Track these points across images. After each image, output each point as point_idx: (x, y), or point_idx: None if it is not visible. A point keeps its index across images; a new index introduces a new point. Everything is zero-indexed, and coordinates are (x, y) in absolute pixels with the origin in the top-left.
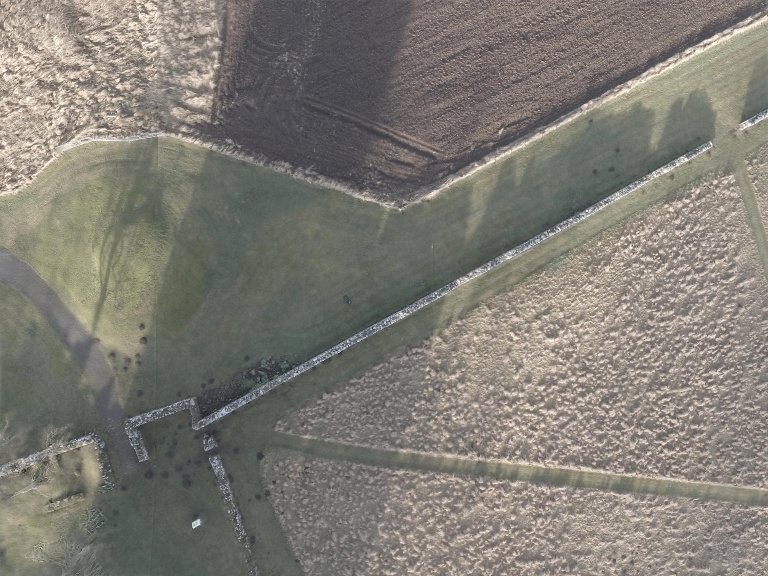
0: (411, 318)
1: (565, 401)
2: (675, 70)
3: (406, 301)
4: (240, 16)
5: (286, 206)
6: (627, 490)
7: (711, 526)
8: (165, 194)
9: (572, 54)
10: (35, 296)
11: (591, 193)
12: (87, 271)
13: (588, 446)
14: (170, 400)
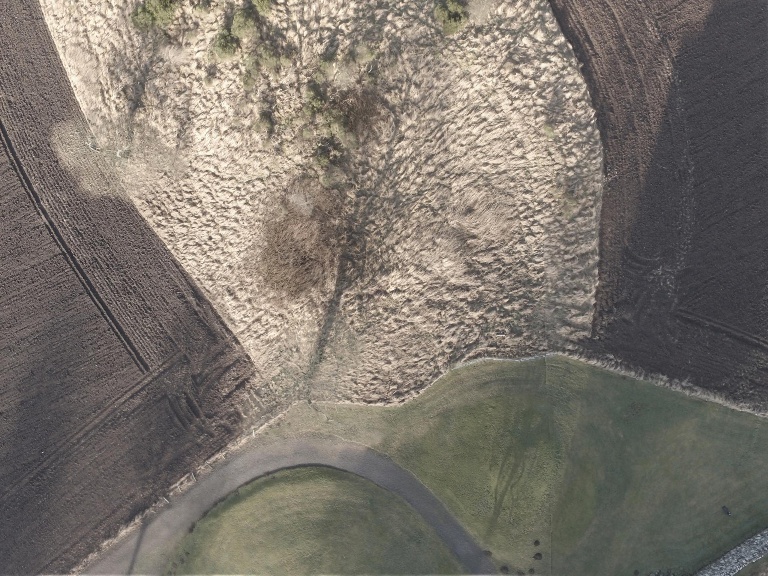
0: None
1: None
2: None
3: None
4: (616, 232)
5: (665, 419)
6: None
7: None
8: (556, 412)
9: None
10: (420, 504)
11: None
12: (480, 486)
13: None
14: None
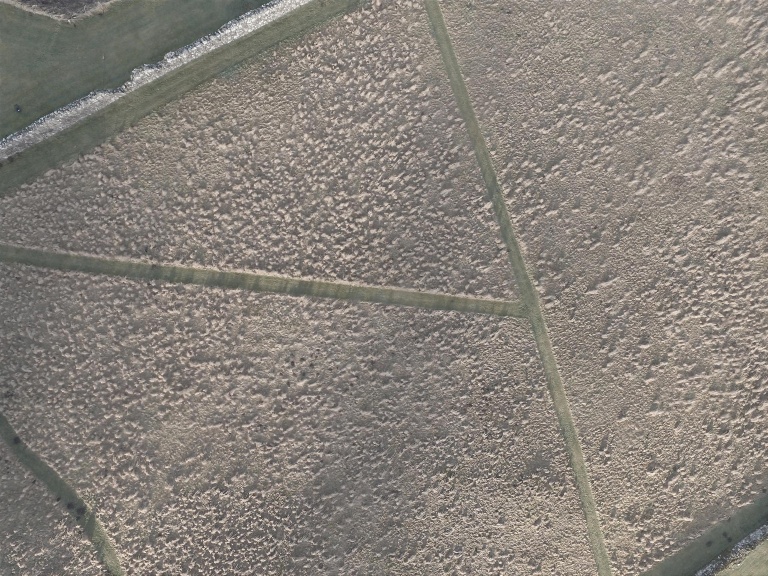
0: (83, 126)
1: (240, 206)
2: None
3: None
4: None
5: None
6: (304, 294)
7: (394, 331)
8: None
9: None
10: None
11: None
12: None
13: (264, 250)
14: None
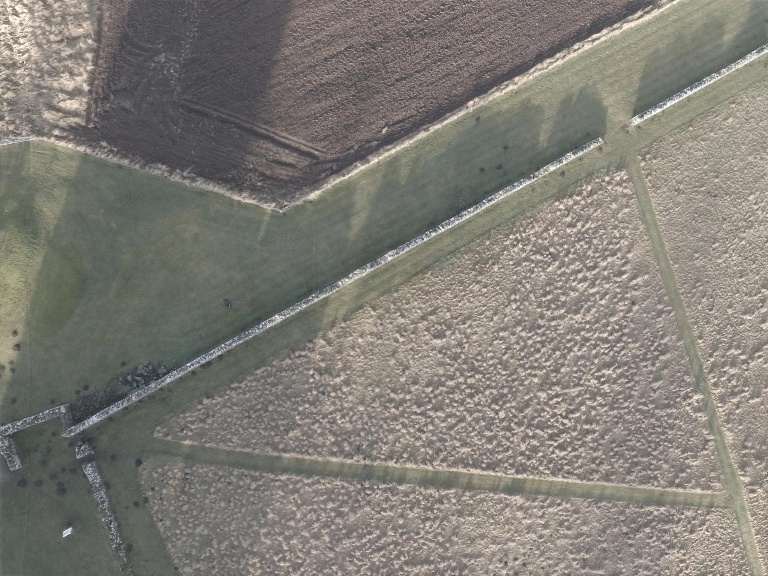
0: (294, 321)
1: (453, 402)
2: (564, 66)
3: (287, 304)
4: (115, 17)
5: (163, 209)
6: (518, 492)
7: (605, 527)
8: (37, 199)
9: (457, 51)
10: None
11: (478, 191)
12: None
13: (477, 448)
14: (43, 407)
